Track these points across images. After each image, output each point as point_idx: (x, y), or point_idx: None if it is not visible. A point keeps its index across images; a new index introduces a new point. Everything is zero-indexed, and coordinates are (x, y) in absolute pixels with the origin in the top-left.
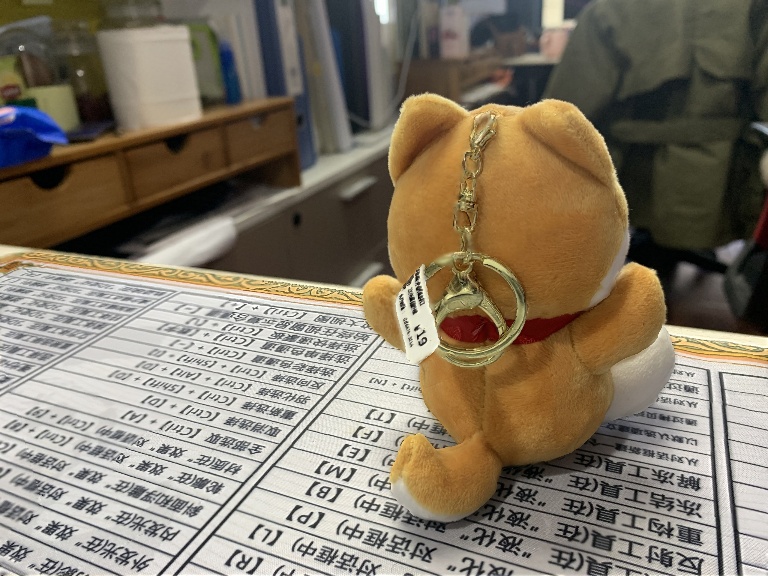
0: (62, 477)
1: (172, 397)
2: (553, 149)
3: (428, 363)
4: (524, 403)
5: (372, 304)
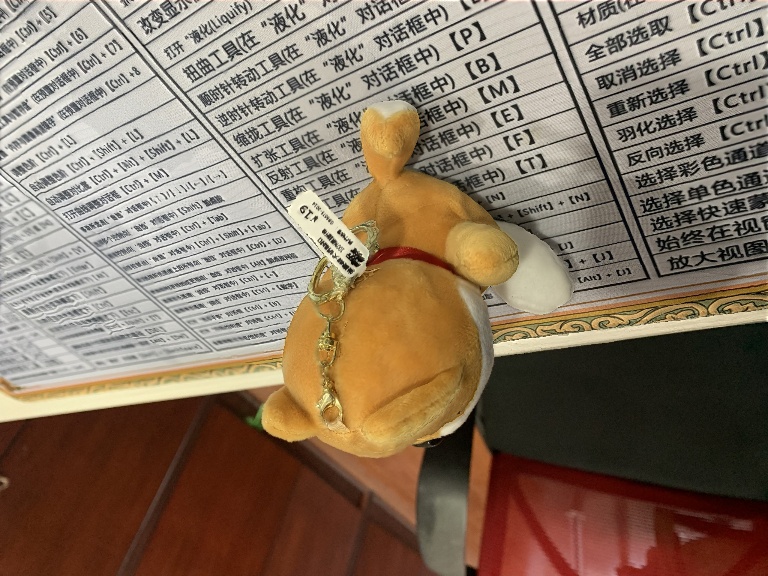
0: None
1: None
2: (289, 399)
3: (441, 222)
4: (350, 221)
5: (479, 248)
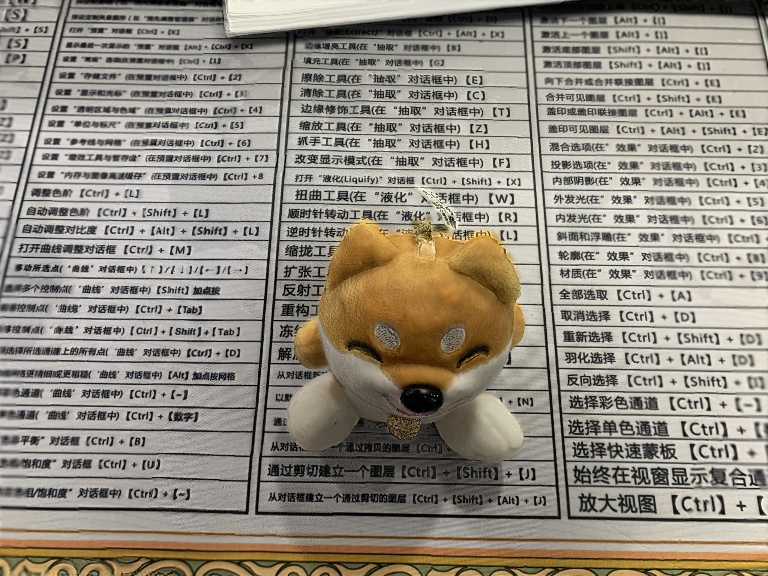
0: (665, 231)
1: (676, 326)
2: None
3: None
4: None
5: None
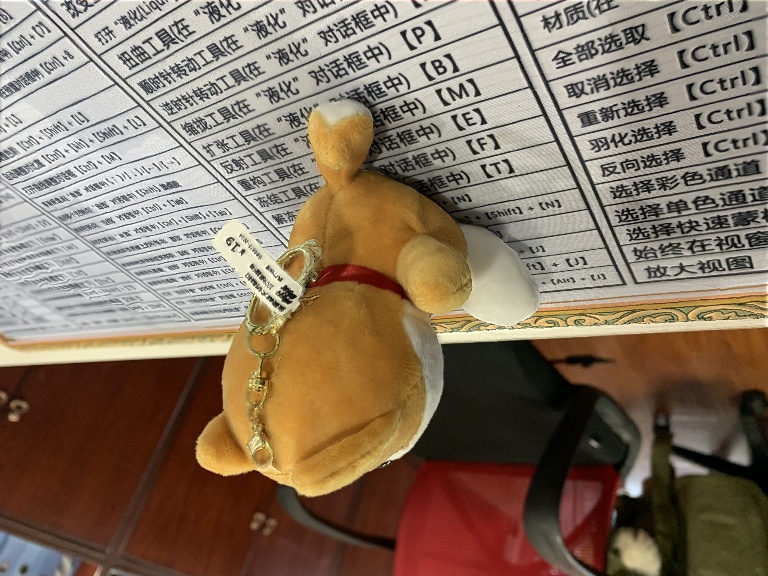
0: None
1: None
2: (224, 432)
3: (394, 237)
4: (300, 229)
5: (426, 277)
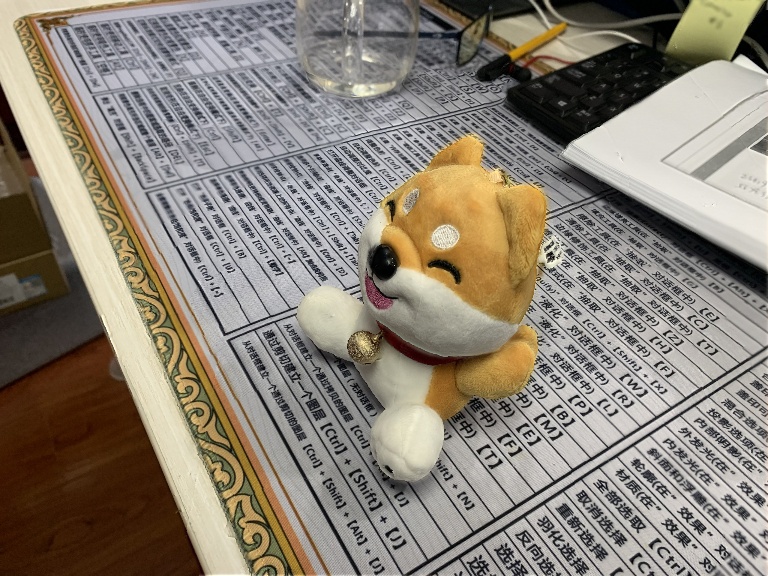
0: None
1: None
2: None
3: None
4: None
5: None
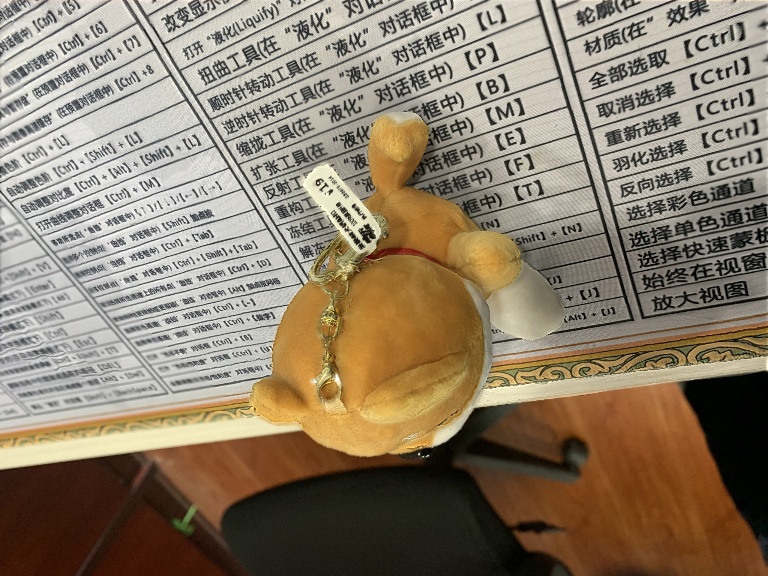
0: None
1: None
2: (281, 381)
3: (444, 229)
4: None
5: (486, 245)
